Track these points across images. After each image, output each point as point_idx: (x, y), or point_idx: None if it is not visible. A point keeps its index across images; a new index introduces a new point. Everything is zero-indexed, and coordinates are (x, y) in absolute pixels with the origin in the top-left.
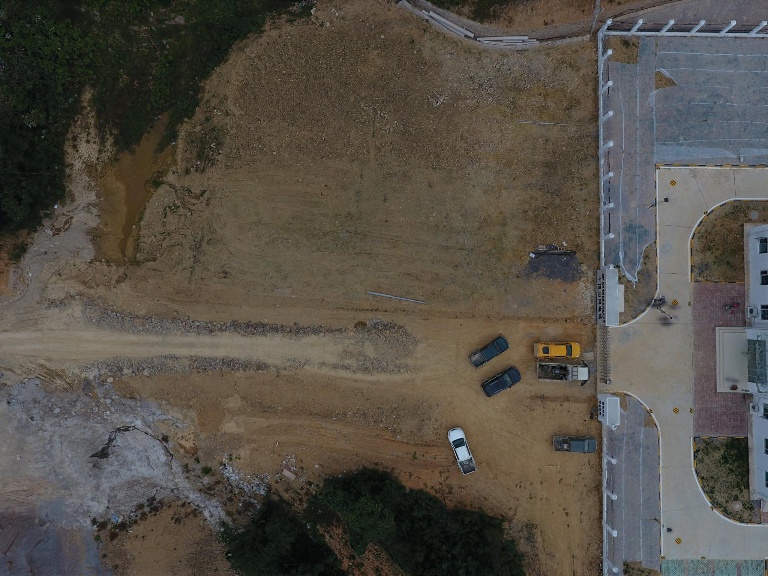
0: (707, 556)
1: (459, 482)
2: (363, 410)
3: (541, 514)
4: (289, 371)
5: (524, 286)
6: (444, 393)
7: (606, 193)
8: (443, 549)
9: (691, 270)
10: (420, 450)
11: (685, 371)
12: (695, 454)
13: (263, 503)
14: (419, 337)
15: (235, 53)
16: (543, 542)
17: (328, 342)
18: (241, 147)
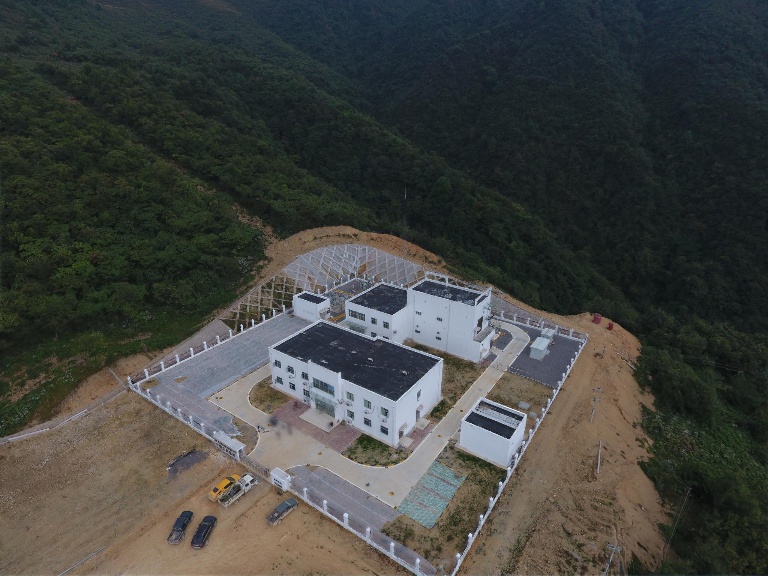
0: (412, 485)
1: None
2: None
3: (306, 565)
4: None
5: (176, 483)
6: None
7: None
8: None
9: (263, 412)
10: None
11: (305, 439)
12: (350, 458)
13: None
14: (119, 571)
15: None
16: None
17: None
18: None
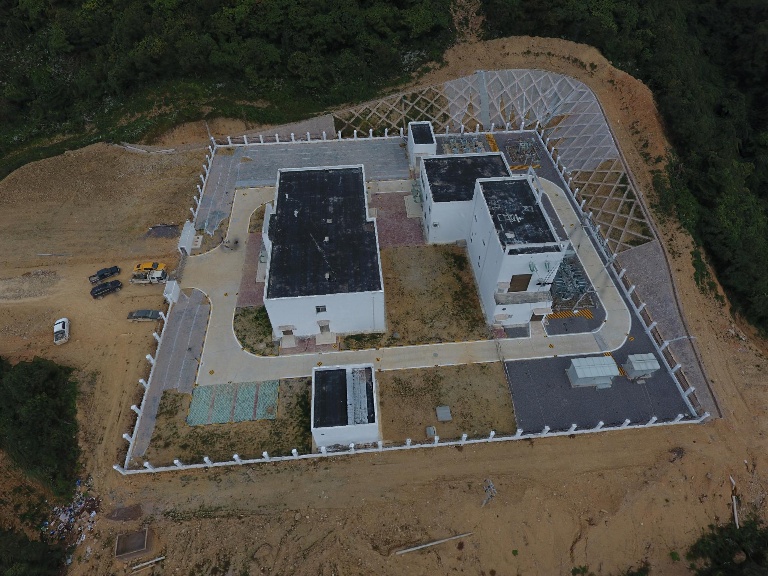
0: (233, 381)
1: (54, 355)
2: (8, 327)
3: (107, 365)
4: None
5: (141, 242)
6: (67, 303)
7: (204, 200)
8: None
9: (249, 228)
10: (35, 340)
11: (236, 274)
12: (235, 317)
13: None
14: (63, 276)
15: None
16: (102, 383)
17: None
18: None
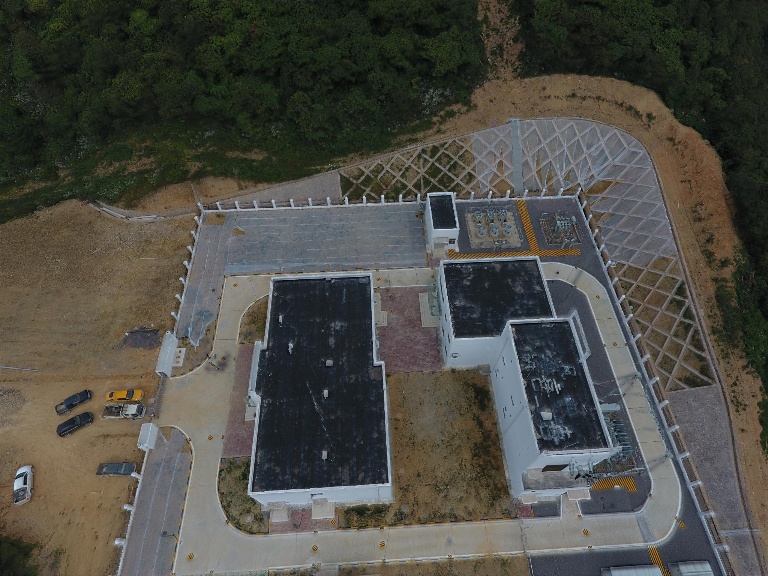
0: (215, 570)
1: (15, 516)
2: None
3: (73, 538)
4: None
5: (115, 354)
6: (31, 439)
7: (188, 293)
8: None
9: (239, 336)
10: None
11: (223, 407)
12: (220, 473)
13: None
14: (28, 398)
15: None
16: (67, 566)
17: None
18: None
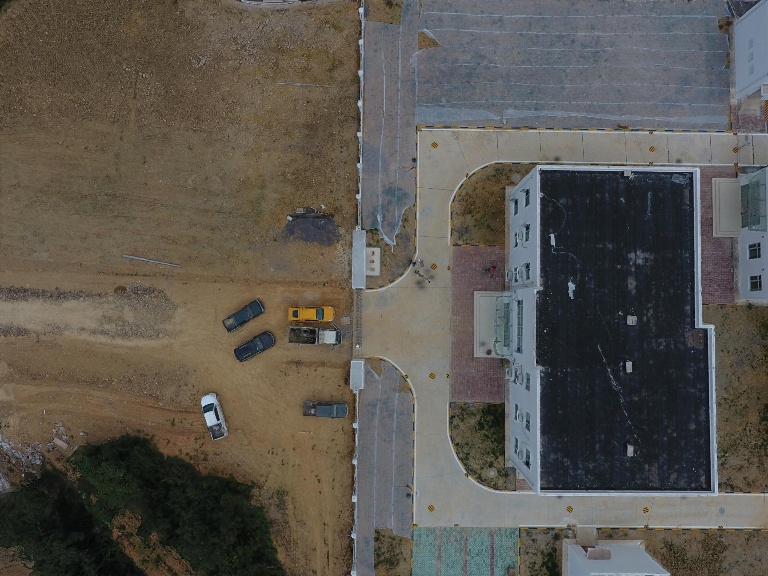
0: (460, 524)
1: (214, 449)
2: (128, 377)
3: (293, 481)
4: (49, 336)
5: (281, 249)
6: (201, 358)
7: (366, 155)
8: (182, 515)
9: (451, 233)
10: (178, 416)
11: (442, 336)
12: (450, 420)
13: (41, 473)
14: (178, 302)
15: (0, 14)
16: (294, 509)
17: (88, 307)
18: (2, 109)
